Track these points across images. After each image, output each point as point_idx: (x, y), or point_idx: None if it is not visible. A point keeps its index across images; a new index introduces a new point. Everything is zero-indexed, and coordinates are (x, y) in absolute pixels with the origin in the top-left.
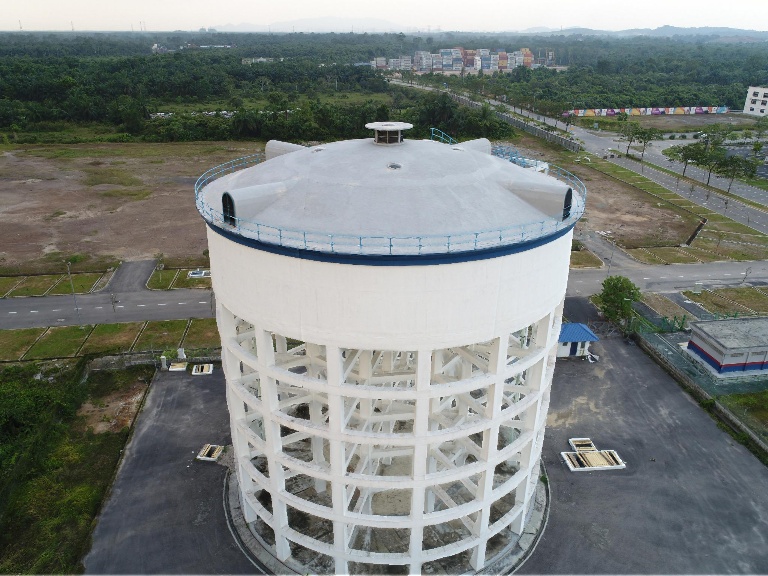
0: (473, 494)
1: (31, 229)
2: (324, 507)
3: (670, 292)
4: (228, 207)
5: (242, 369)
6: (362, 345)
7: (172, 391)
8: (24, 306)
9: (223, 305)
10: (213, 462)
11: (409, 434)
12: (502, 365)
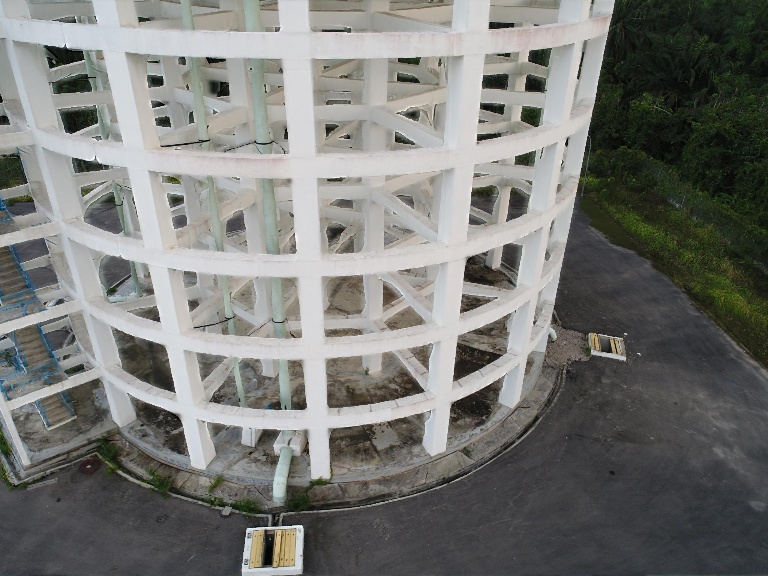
0: None
1: None
2: None
3: None
4: None
5: None
6: None
7: None
8: None
9: None
10: None
11: None
12: None
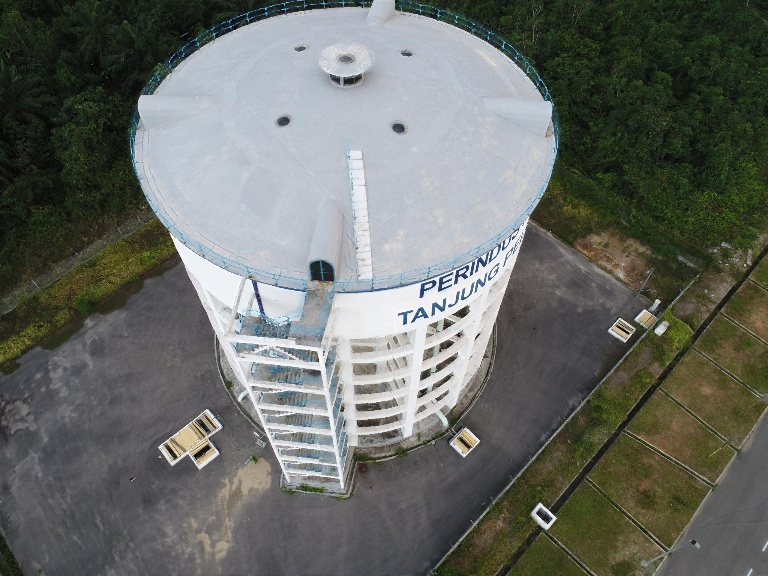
0: None
1: None
2: None
3: None
4: None
5: (593, 355)
6: None
7: (604, 292)
8: None
9: None
10: None
11: None
12: None
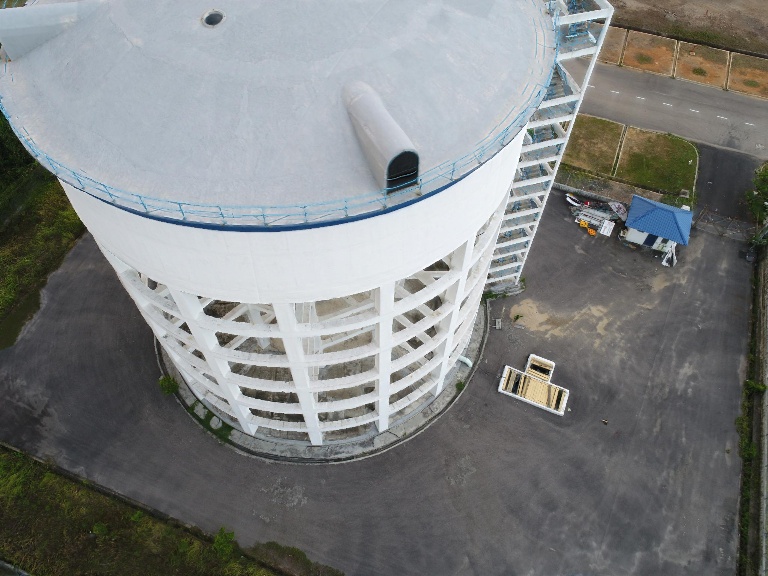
0: None
1: None
2: None
3: None
4: None
5: None
6: (115, 254)
7: None
8: None
9: None
10: None
11: None
12: (287, 326)
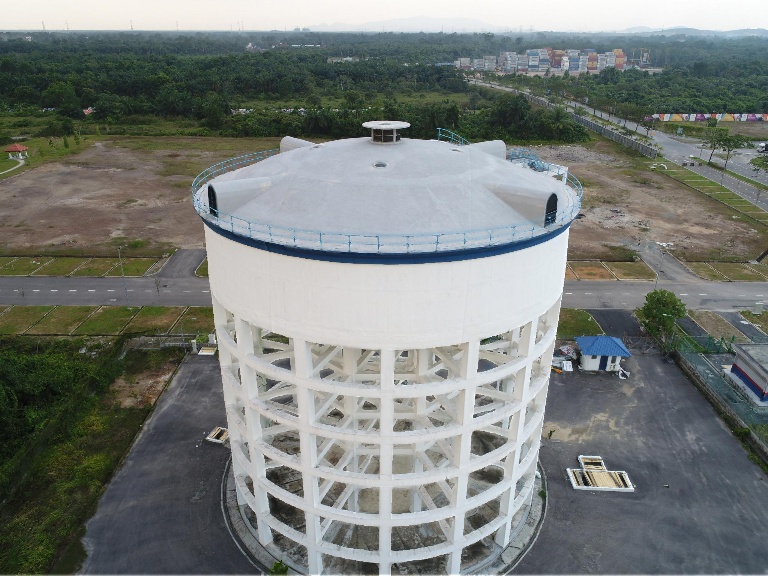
0: None
1: (104, 214)
2: (297, 497)
3: (726, 311)
4: (212, 199)
5: None
6: (326, 340)
7: (197, 374)
8: (84, 285)
9: (213, 293)
10: (220, 444)
11: (375, 432)
12: (473, 371)
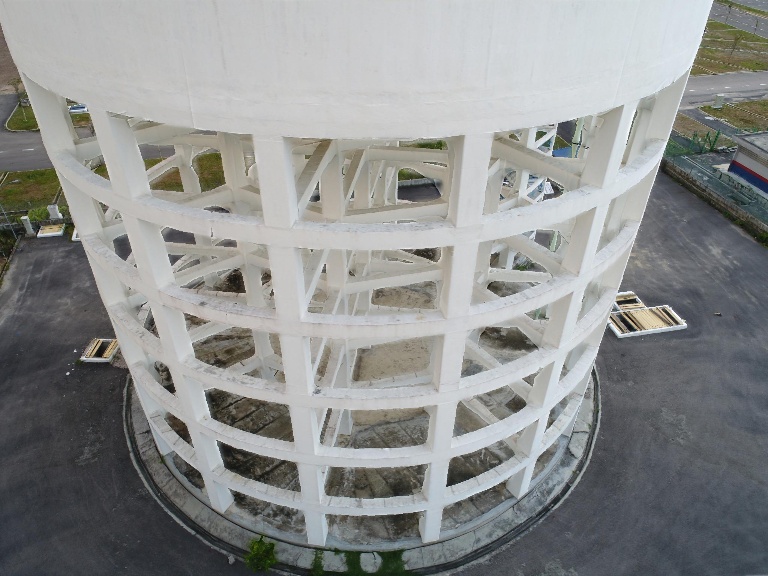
0: (521, 395)
1: None
2: (279, 442)
3: (685, 108)
4: None
5: None
6: (337, 127)
7: (42, 265)
8: None
9: (26, 76)
10: (106, 364)
11: (433, 314)
12: (614, 169)
